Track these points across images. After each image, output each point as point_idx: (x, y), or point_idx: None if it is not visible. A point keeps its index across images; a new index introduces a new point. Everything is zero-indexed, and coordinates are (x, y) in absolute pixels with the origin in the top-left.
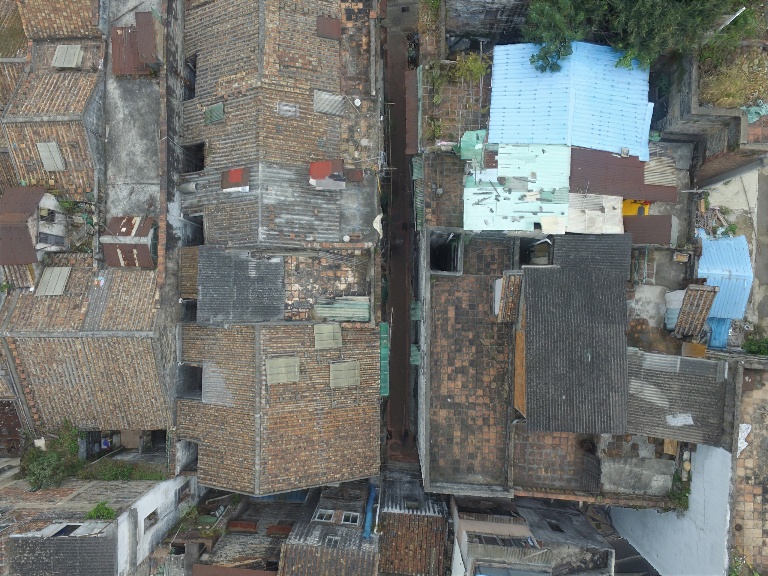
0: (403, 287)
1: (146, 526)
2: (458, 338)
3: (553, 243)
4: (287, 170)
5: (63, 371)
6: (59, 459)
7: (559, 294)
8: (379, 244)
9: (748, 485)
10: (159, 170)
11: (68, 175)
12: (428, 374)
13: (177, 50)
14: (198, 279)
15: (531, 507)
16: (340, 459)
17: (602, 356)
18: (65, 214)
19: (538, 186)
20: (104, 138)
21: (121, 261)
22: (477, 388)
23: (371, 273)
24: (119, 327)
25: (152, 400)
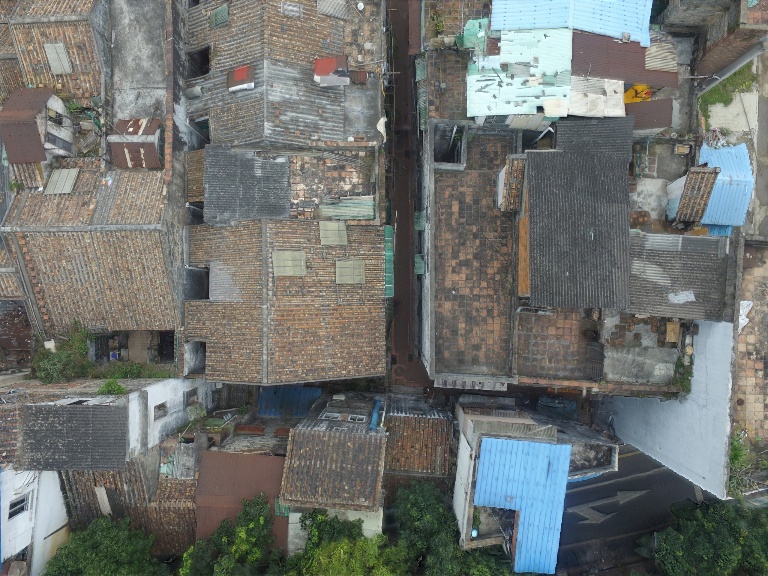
0: (406, 214)
1: (156, 415)
2: (462, 232)
3: (555, 130)
4: (292, 69)
5: (72, 268)
6: (69, 356)
7: (562, 176)
8: (383, 146)
9: (750, 360)
10: (165, 70)
11: (75, 78)
12: (433, 264)
13: None
14: (205, 177)
15: (535, 418)
16: (346, 356)
17: (605, 234)
18: (72, 119)
19: (540, 71)
20: (110, 43)
21: (128, 162)
22: (481, 280)
23: (375, 171)
24: (127, 221)
25: (160, 298)
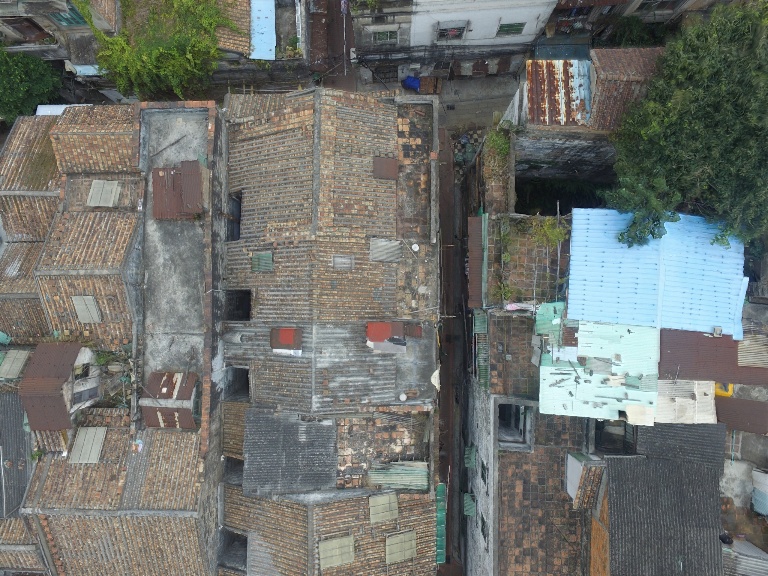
0: (447, 404)
1: None
2: (526, 516)
3: (636, 427)
4: (342, 329)
5: (98, 546)
6: None
7: (646, 490)
8: (437, 401)
9: None
10: (203, 327)
11: (104, 327)
12: (496, 562)
13: (221, 188)
14: (244, 446)
15: None
16: None
17: (695, 564)
18: (100, 365)
19: (623, 370)
20: (143, 285)
21: (161, 423)
22: (547, 572)
23: (431, 439)
24: (160, 505)
25: (193, 574)
